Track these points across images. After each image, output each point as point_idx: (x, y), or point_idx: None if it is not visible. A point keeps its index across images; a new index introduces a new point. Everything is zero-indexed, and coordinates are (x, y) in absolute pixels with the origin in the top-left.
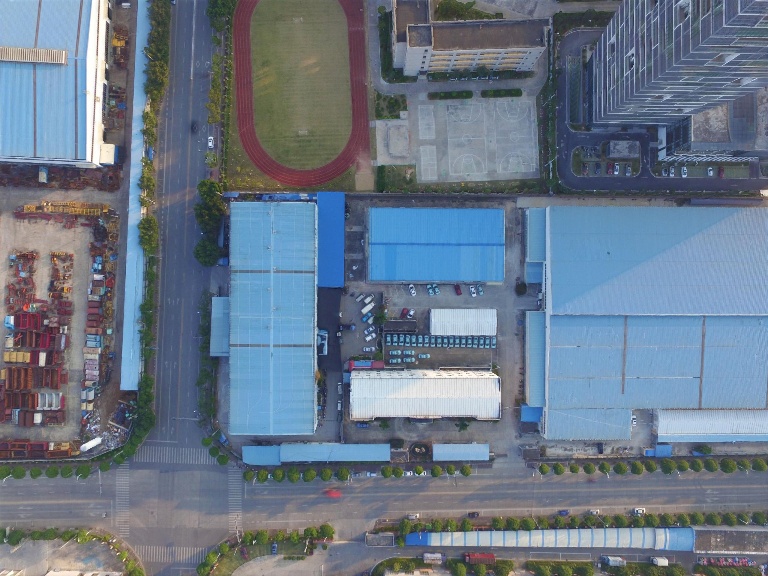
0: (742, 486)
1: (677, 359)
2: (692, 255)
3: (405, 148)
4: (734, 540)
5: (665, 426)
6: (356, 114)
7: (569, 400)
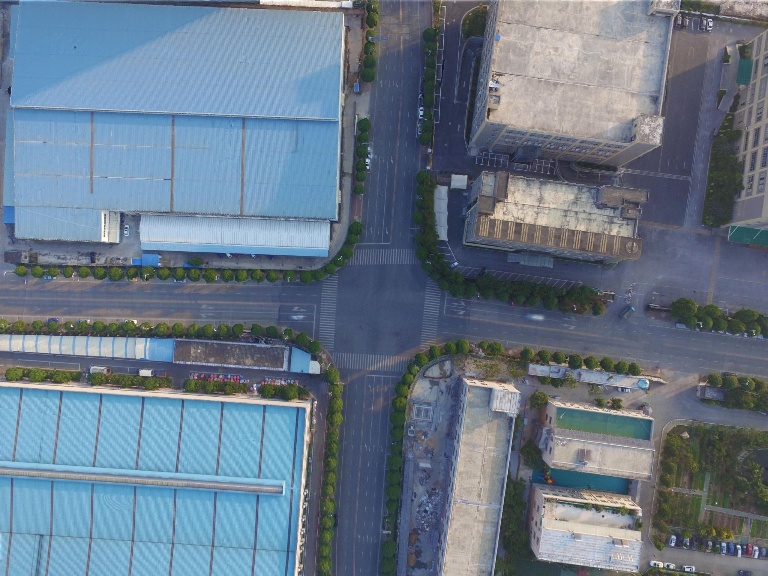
0: (238, 302)
1: (146, 159)
2: (162, 52)
3: None
4: (215, 352)
5: (146, 232)
6: None
7: (37, 197)
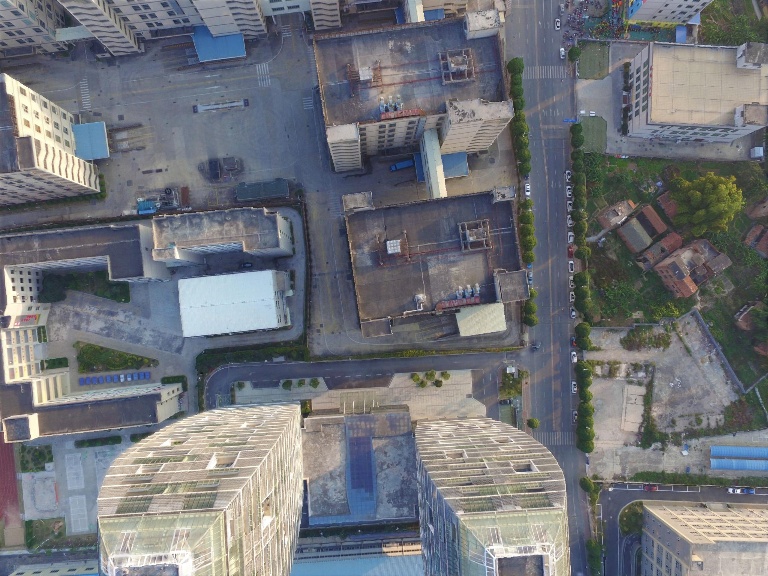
0: None
1: None
2: None
3: (52, 502)
4: None
5: None
6: (2, 467)
7: None
